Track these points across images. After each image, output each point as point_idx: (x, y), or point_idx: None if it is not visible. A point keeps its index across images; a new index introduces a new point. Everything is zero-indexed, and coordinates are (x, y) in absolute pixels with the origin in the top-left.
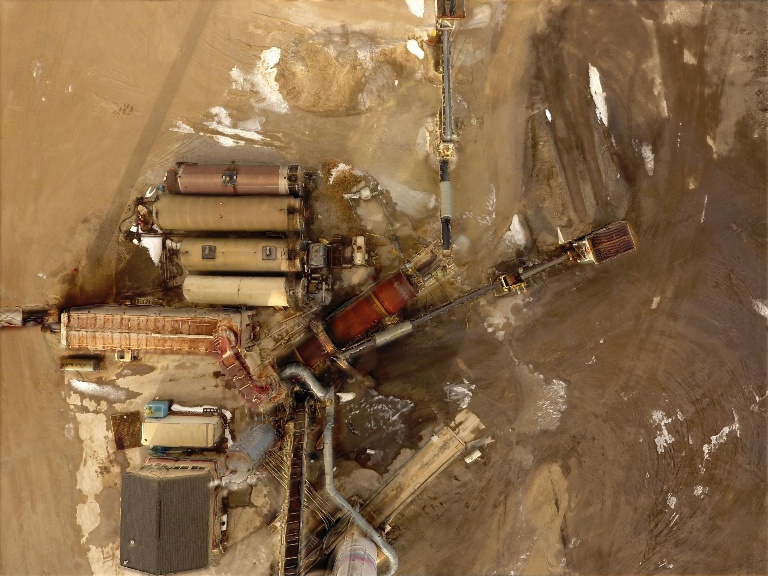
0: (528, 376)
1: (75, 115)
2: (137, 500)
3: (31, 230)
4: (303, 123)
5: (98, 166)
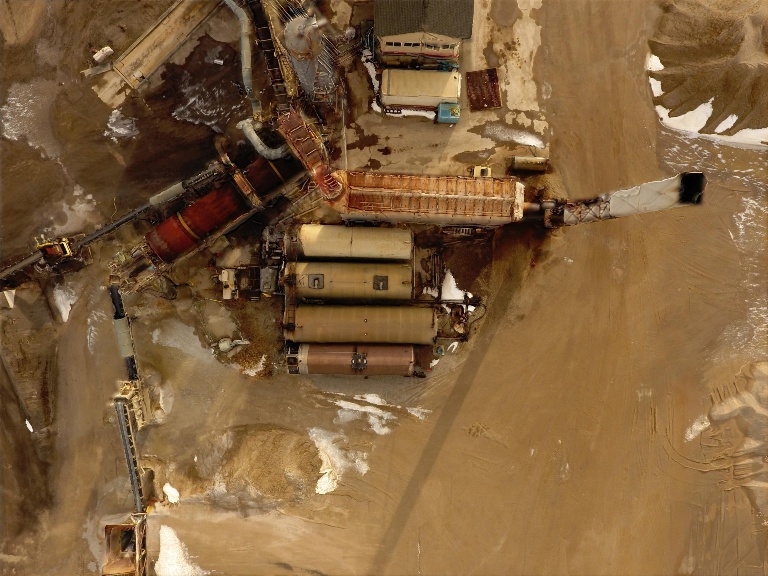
0: (46, 145)
1: (528, 426)
2: (453, 7)
3: (578, 308)
4: (294, 418)
5: (506, 374)
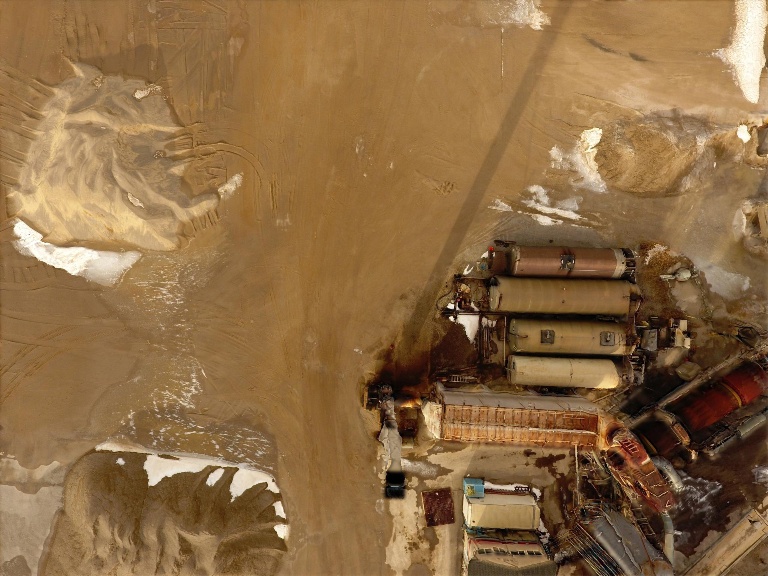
0: None
1: (396, 192)
2: None
3: (349, 305)
4: (620, 203)
5: (417, 243)
